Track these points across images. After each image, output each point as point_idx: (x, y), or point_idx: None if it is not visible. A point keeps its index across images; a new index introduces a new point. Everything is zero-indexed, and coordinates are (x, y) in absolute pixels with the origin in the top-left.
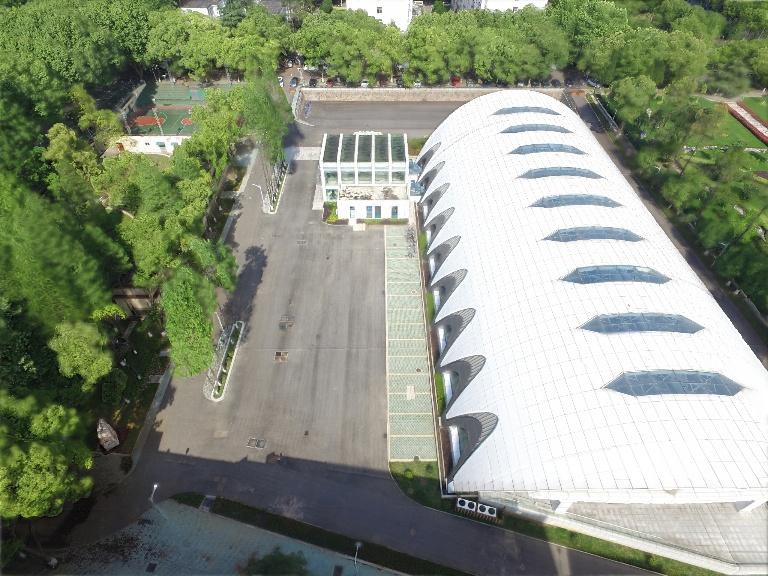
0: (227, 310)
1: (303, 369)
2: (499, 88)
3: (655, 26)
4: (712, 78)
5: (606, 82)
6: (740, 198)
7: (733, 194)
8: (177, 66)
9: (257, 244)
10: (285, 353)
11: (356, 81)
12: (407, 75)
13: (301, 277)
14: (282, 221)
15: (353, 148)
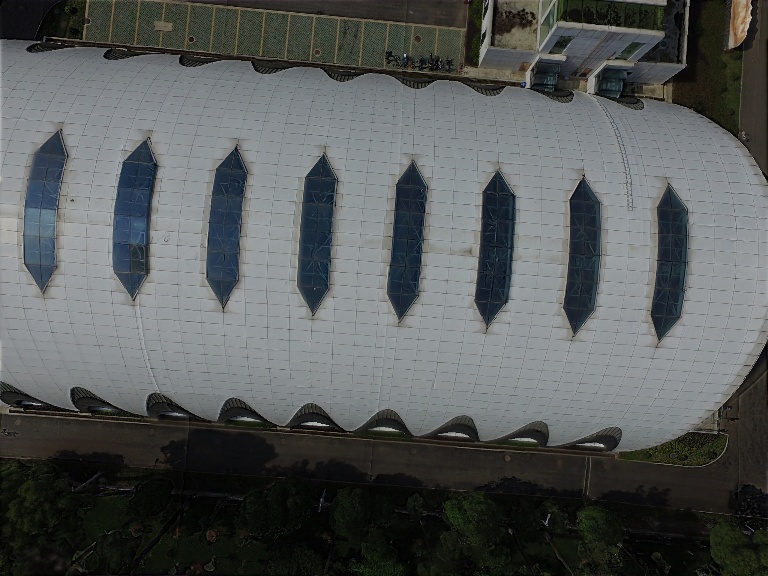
0: None
1: None
2: None
3: None
4: None
5: None
6: None
7: None
8: None
9: None
10: None
11: None
12: None
13: None
14: None
15: None
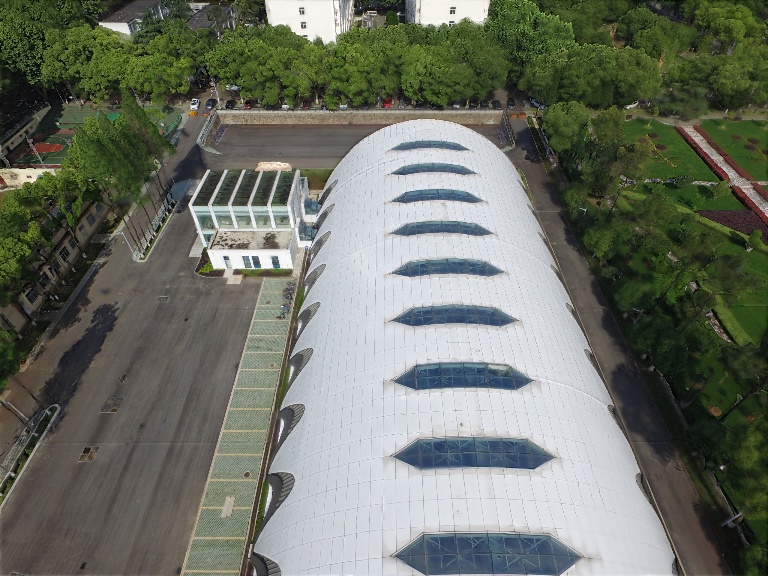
0: (47, 389)
1: (109, 472)
2: (432, 110)
3: (621, 37)
4: (667, 99)
5: (549, 104)
6: (677, 244)
7: (666, 241)
8: (80, 88)
9: (111, 301)
10: (95, 449)
11: (272, 104)
12: (329, 97)
13: (147, 345)
14: (149, 272)
15: (233, 188)
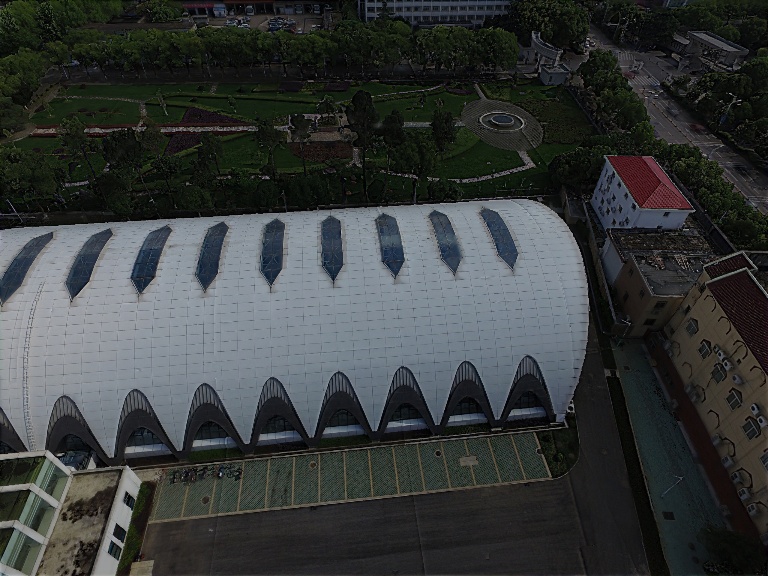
0: None
1: None
2: None
3: None
4: None
5: None
6: None
7: None
8: None
9: None
10: None
11: None
12: None
13: None
14: None
15: None
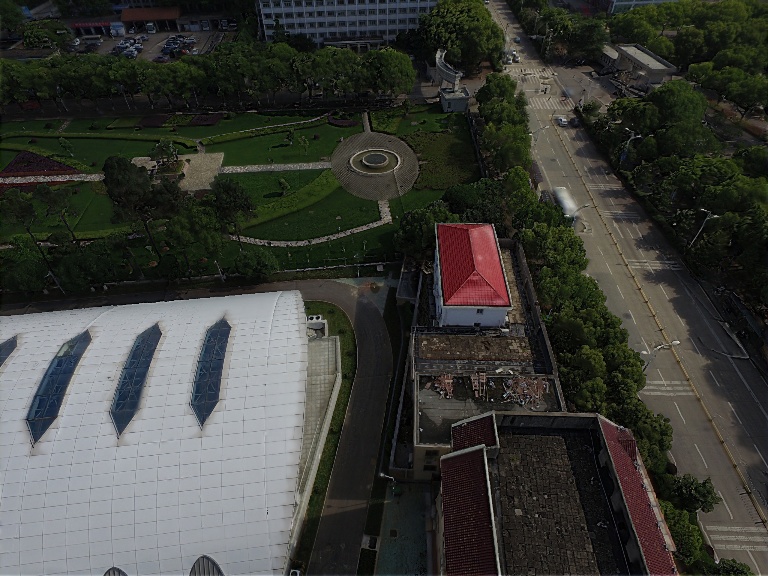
0: None
1: None
2: None
3: None
4: None
5: None
6: None
7: None
8: None
9: None
10: None
11: None
12: None
13: None
14: None
15: None
